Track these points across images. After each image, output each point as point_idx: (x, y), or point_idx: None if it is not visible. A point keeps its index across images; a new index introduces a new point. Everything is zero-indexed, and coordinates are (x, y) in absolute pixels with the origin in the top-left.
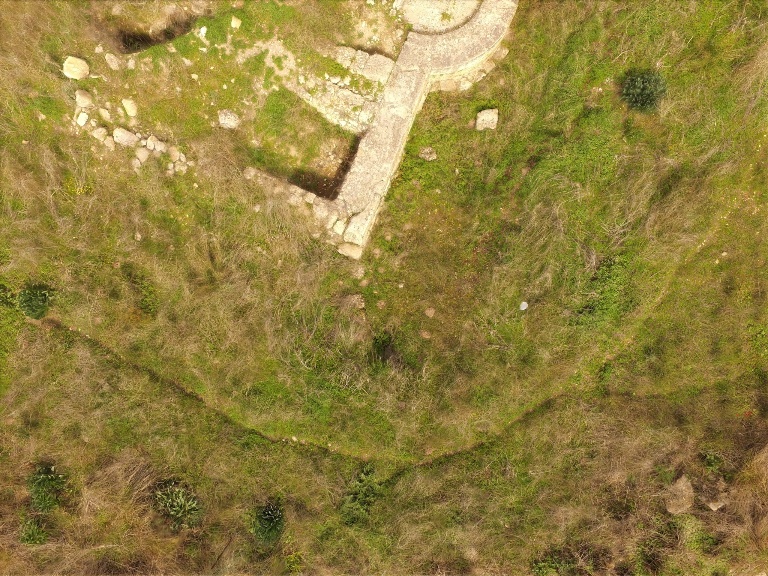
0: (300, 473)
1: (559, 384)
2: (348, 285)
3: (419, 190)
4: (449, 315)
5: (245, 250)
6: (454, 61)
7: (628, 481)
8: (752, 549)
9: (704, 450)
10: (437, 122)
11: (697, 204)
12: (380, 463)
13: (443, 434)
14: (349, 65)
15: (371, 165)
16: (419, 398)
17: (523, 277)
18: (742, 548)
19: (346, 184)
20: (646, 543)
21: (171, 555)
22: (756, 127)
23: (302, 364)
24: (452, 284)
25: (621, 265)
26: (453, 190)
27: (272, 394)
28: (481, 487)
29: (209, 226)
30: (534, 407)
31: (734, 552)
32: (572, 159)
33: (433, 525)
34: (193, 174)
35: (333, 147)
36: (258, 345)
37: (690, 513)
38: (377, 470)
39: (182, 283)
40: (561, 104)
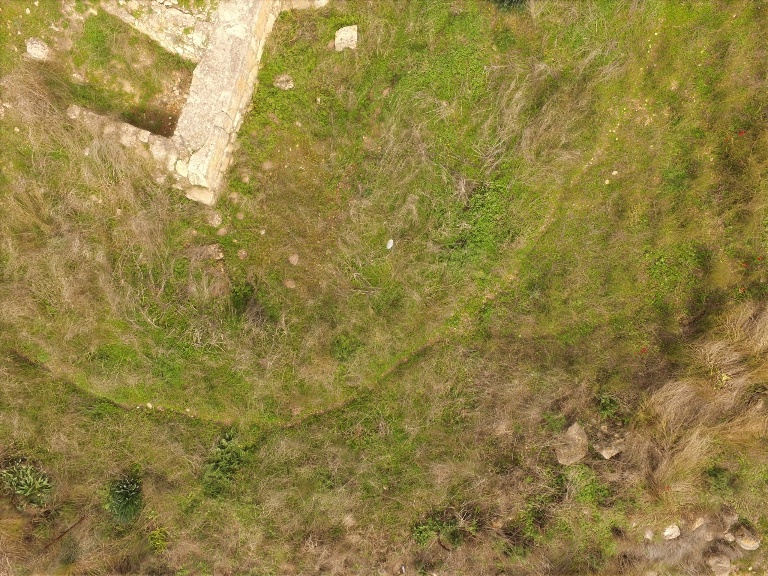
0: (155, 442)
1: (435, 329)
2: (203, 234)
3: (275, 123)
4: (313, 260)
5: (74, 198)
6: None
7: (516, 432)
8: (651, 499)
9: (598, 393)
10: (290, 45)
11: (577, 116)
12: (244, 427)
13: (309, 391)
14: None
15: (208, 94)
16: (276, 352)
17: (387, 212)
18: (639, 498)
19: (182, 117)
20: (536, 499)
21: (15, 537)
22: (644, 24)
23: (150, 323)
24: None
25: (497, 191)
26: (314, 121)
27: (120, 357)
28: (354, 447)
29: (35, 174)
30: (409, 356)
31: (631, 503)
32: (436, 74)
33: (297, 490)
34: (13, 117)
35: (177, 81)
36: (101, 304)
37: (584, 463)
38: (241, 435)
39: (6, 239)
40: (424, 13)
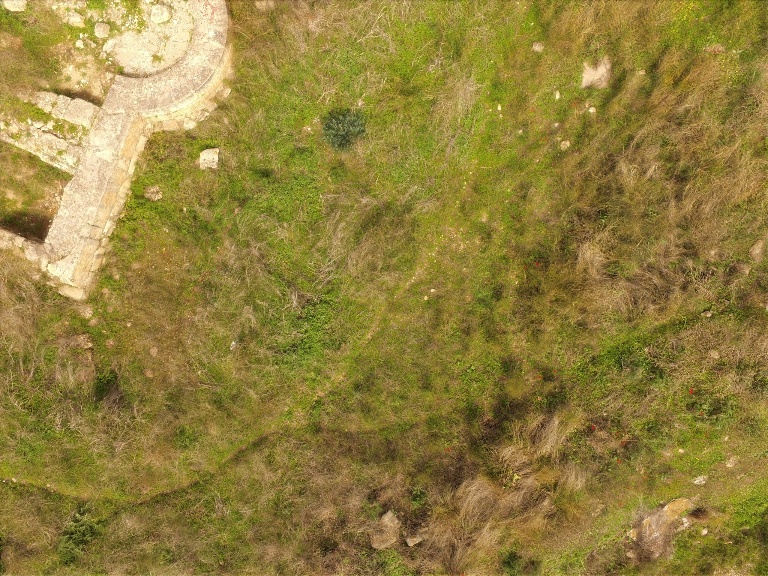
0: (14, 515)
1: (270, 422)
2: (75, 325)
3: (144, 230)
4: (168, 354)
5: None
6: (161, 103)
7: (337, 517)
8: None
9: (410, 485)
10: (160, 162)
11: (396, 243)
12: (98, 503)
13: (157, 473)
14: (50, 110)
15: (76, 209)
16: (125, 439)
17: (231, 317)
18: None
19: (52, 228)
20: None
21: None
22: (459, 165)
23: (17, 406)
24: (174, 323)
25: (327, 304)
26: (179, 229)
27: None
28: (193, 525)
29: None
30: (247, 445)
31: None
32: (278, 199)
33: (136, 565)
34: None
35: (59, 188)
36: None
37: (394, 548)
38: (95, 510)
39: None
40: (274, 144)
